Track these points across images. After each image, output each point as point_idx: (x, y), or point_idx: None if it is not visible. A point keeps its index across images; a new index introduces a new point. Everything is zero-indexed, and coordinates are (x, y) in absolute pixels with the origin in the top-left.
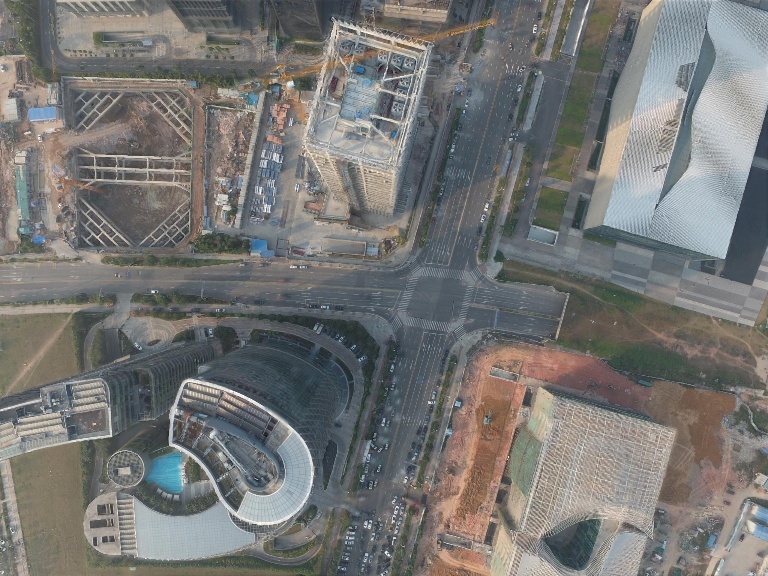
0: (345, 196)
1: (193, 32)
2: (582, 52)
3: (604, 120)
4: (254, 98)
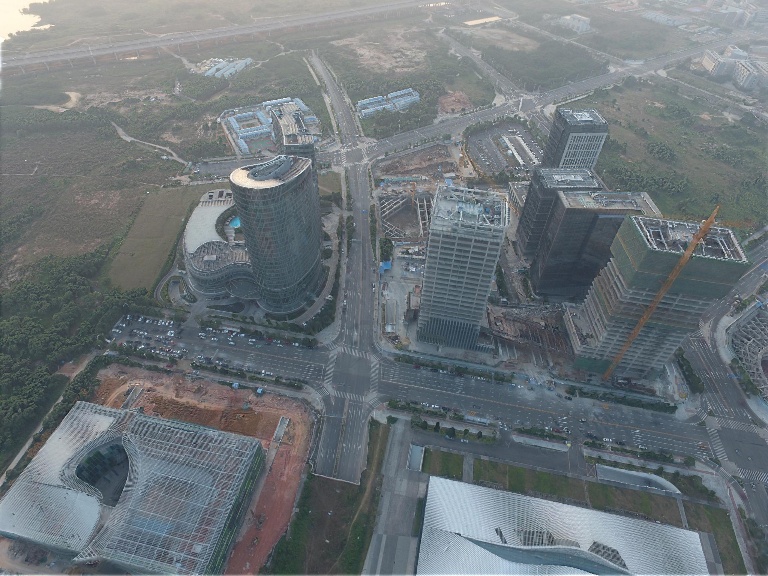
0: None
1: None
2: (605, 487)
3: None
4: None
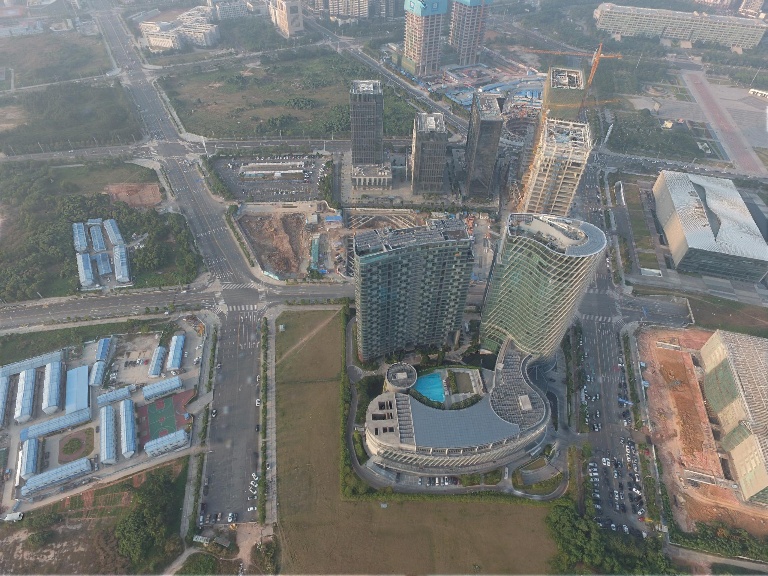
0: None
1: (416, 195)
2: (628, 204)
3: (657, 227)
4: (453, 216)
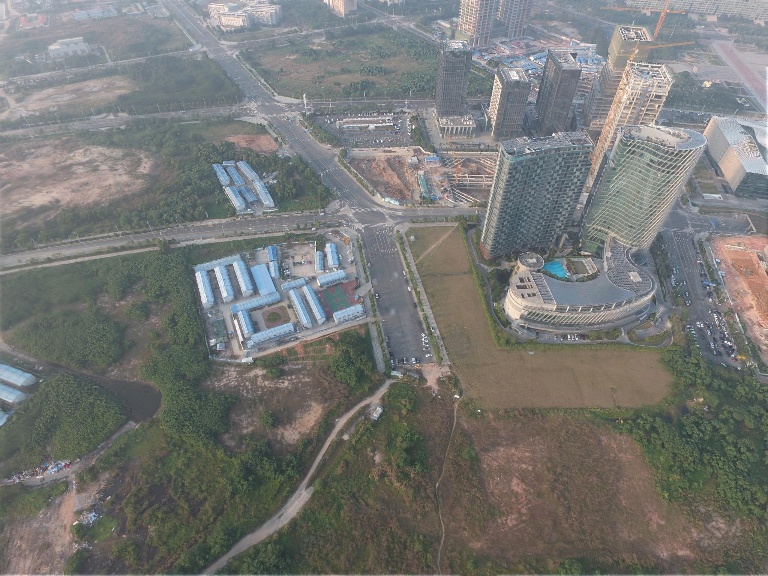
0: None
1: (496, 141)
2: None
3: None
4: None
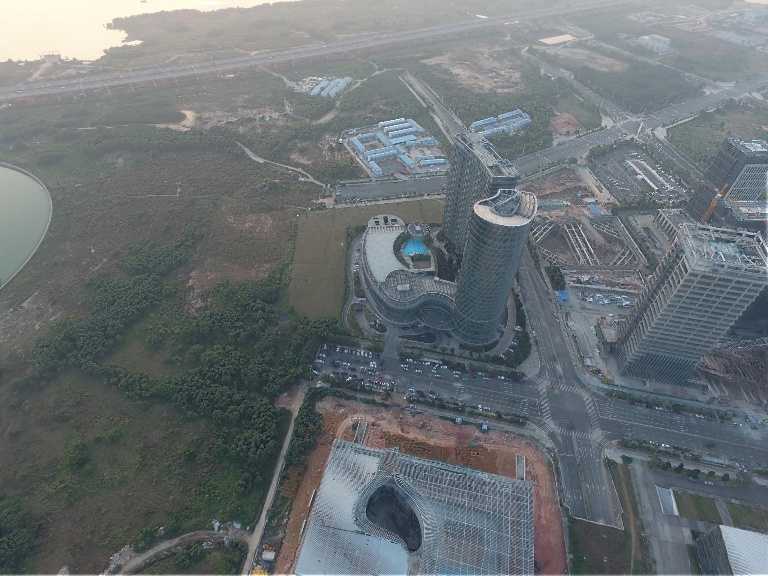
0: None
1: None
2: None
3: None
4: None
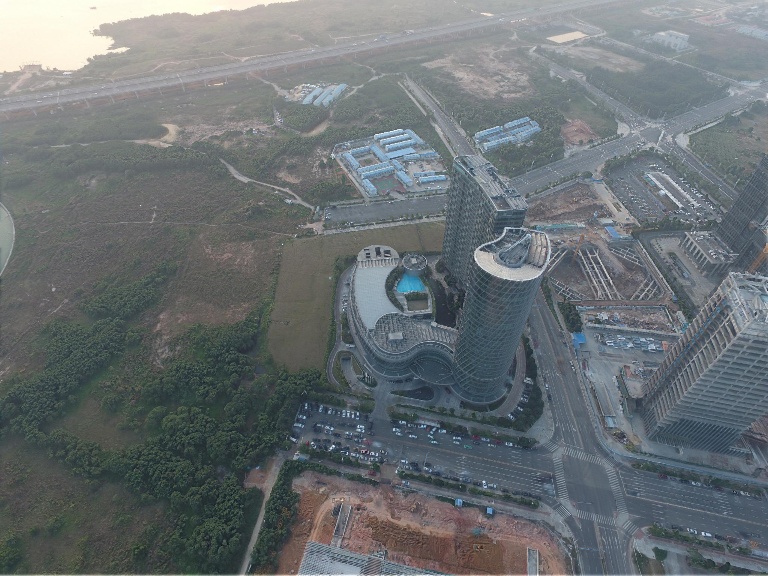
0: (659, 378)
1: None
2: None
3: None
4: None
